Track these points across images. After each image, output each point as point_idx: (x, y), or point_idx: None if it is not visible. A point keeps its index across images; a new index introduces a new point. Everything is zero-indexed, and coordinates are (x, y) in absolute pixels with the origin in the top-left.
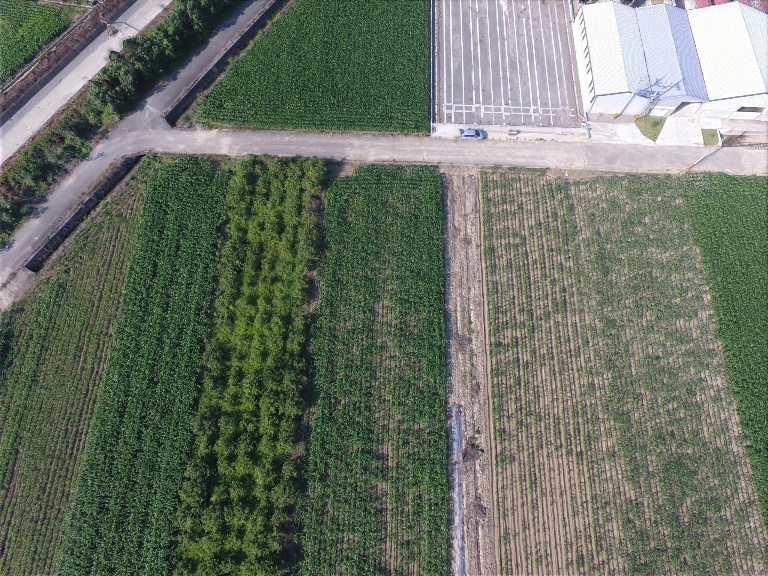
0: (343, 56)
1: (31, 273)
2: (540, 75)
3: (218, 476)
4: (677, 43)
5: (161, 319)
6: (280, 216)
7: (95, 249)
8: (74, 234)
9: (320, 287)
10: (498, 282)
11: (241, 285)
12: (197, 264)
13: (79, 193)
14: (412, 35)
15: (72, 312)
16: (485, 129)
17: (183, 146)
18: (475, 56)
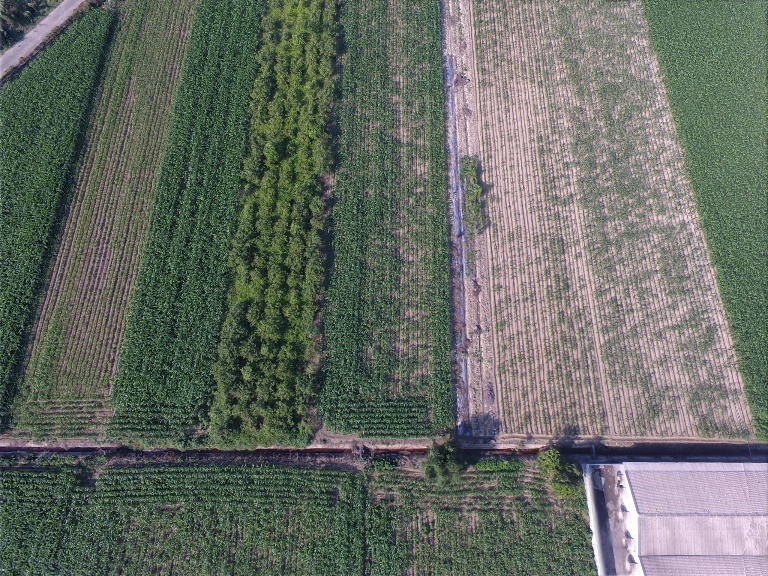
0: None
1: None
2: None
3: (277, 89)
4: None
5: (229, 3)
6: None
7: None
8: None
9: None
10: None
11: None
12: None
13: None
14: None
15: (162, 1)
16: None
17: None
18: None
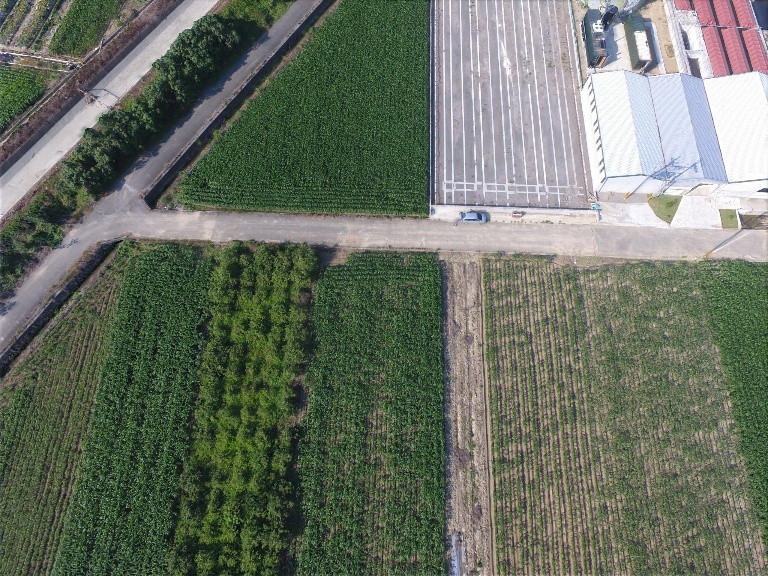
0: (336, 128)
1: None
2: (546, 148)
3: None
4: (693, 118)
5: (135, 434)
6: (266, 312)
7: (66, 350)
8: (43, 333)
9: (309, 395)
10: (502, 387)
11: (223, 392)
12: (176, 369)
13: (50, 286)
14: (410, 104)
15: (39, 425)
16: (488, 210)
17: (163, 231)
18: (477, 127)
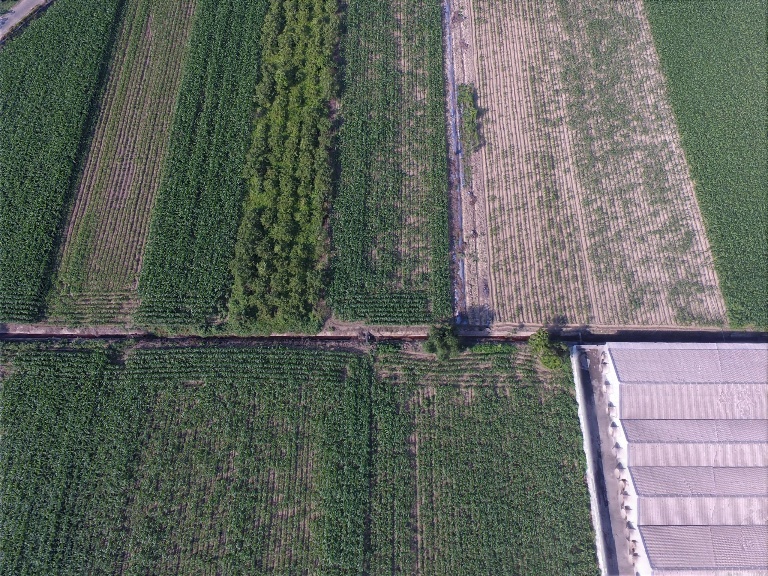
0: None
1: None
2: None
3: (286, 25)
4: None
5: None
6: None
7: None
8: None
9: None
10: None
11: None
12: None
13: None
14: None
15: None
16: None
17: None
18: None
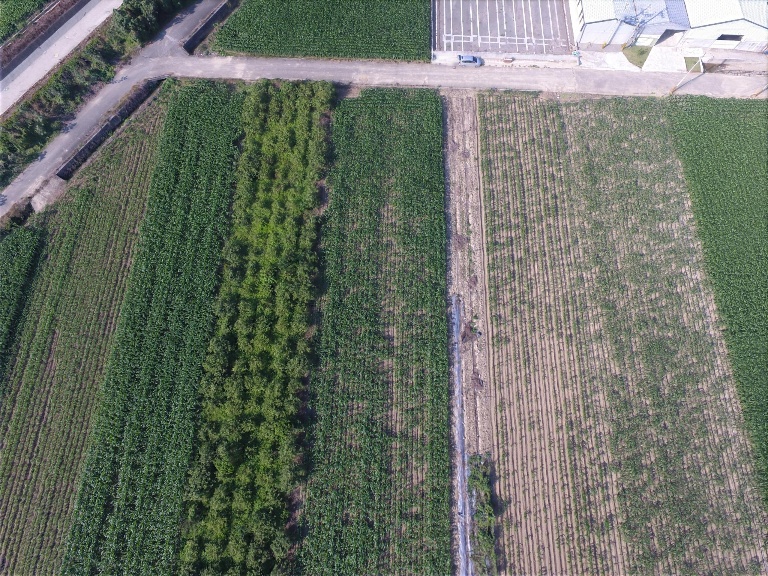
0: None
1: (62, 181)
2: (534, 10)
3: (238, 352)
4: None
5: (183, 219)
6: (292, 131)
7: (121, 160)
8: (101, 147)
9: (330, 193)
10: (494, 190)
11: (256, 191)
12: (216, 172)
13: (105, 111)
14: None
15: (101, 214)
16: (482, 57)
17: (201, 71)
18: None
